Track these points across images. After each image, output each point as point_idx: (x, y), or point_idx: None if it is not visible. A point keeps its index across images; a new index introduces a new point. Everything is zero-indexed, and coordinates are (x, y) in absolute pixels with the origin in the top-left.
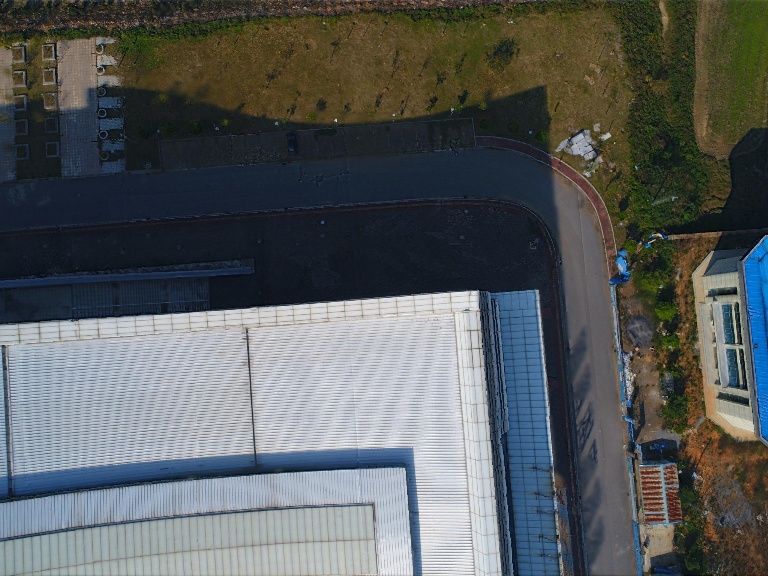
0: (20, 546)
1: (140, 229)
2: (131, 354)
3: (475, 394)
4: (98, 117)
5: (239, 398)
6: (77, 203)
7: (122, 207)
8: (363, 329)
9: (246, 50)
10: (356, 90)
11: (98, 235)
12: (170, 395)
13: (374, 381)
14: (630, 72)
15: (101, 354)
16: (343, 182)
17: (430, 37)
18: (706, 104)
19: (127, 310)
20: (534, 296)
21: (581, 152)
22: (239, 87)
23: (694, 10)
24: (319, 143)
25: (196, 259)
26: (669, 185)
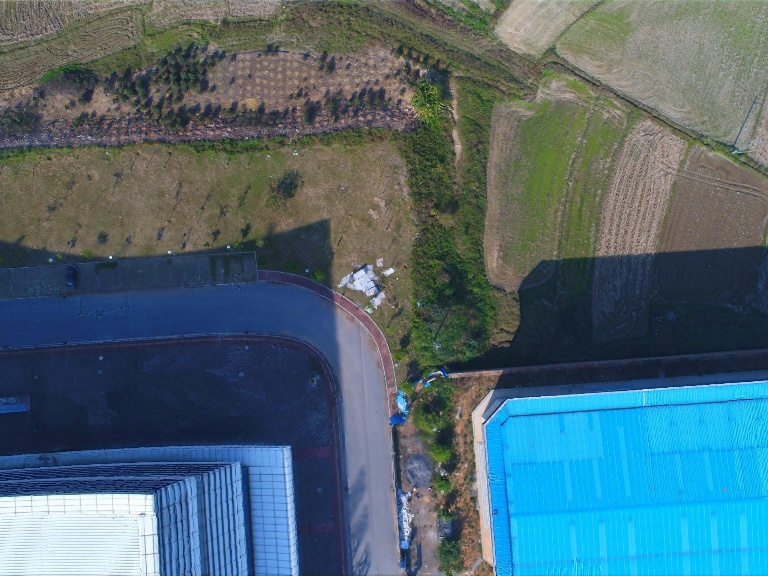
0: None
1: None
2: None
3: None
4: None
5: None
6: None
7: None
8: (54, 522)
9: (27, 181)
10: (138, 223)
11: None
12: None
13: (64, 575)
14: (414, 207)
15: None
16: (123, 316)
17: (214, 169)
18: (497, 235)
19: None
20: (282, 454)
21: (363, 288)
22: (19, 219)
23: (486, 139)
24: (100, 276)
25: None
26: (449, 323)
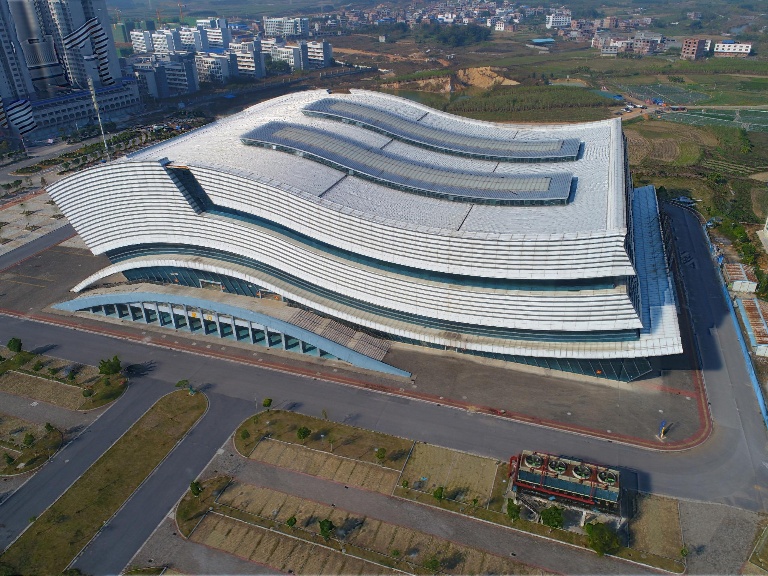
0: None
1: None
2: None
3: None
4: None
5: None
6: None
7: None
8: None
9: None
10: None
11: None
12: None
13: None
14: (712, 190)
15: None
16: None
17: None
18: None
19: None
20: (652, 185)
21: None
22: None
23: None
24: None
25: None
26: None
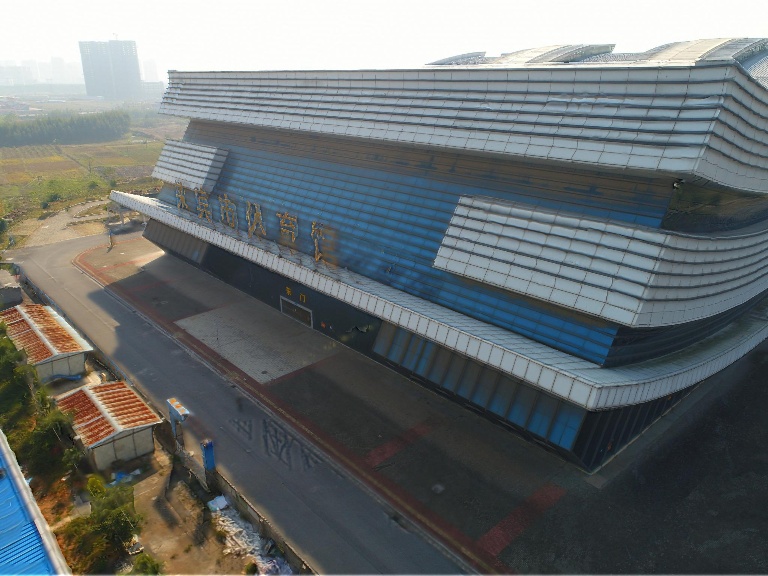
0: None
1: None
2: None
3: None
4: None
5: None
6: None
7: None
8: None
9: None
10: None
11: None
12: None
13: None
14: None
15: None
16: None
17: None
18: None
19: None
20: None
21: None
22: None
23: None
24: None
25: None
26: None
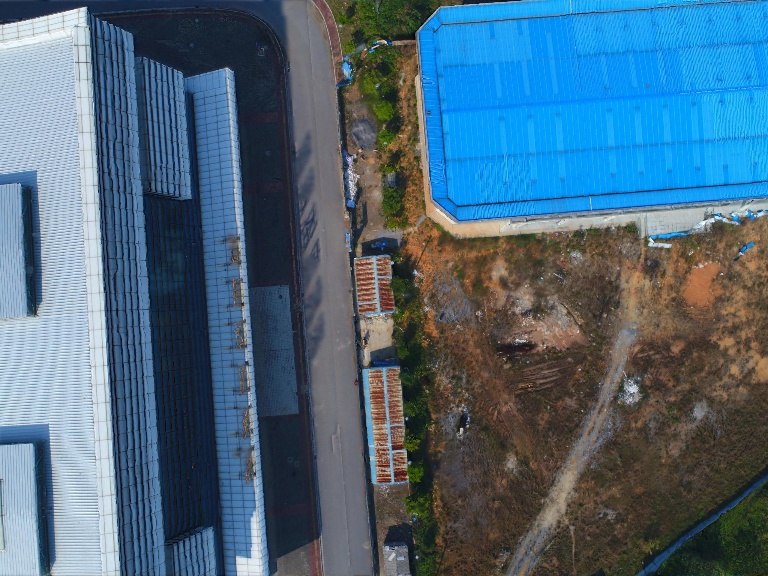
0: None
1: None
2: None
3: (81, 105)
4: None
5: None
6: None
7: None
8: None
9: None
10: None
11: None
12: None
13: (3, 109)
14: None
15: None
16: None
17: None
18: None
19: None
20: (224, 74)
21: None
22: None
23: None
24: None
25: None
26: None
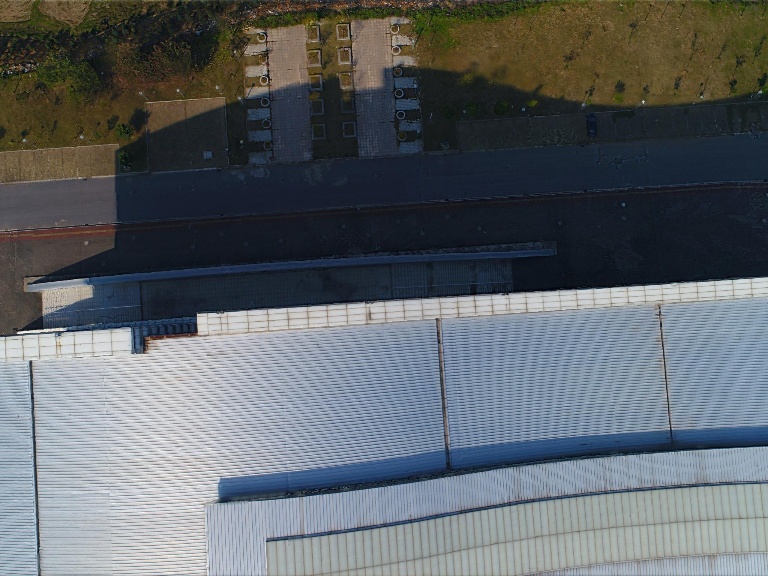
0: (471, 520)
1: (439, 210)
2: (549, 329)
3: None
4: (394, 97)
5: (654, 374)
6: (374, 183)
7: (420, 188)
8: None
9: (543, 31)
10: (655, 72)
11: (398, 216)
12: (586, 371)
13: None
14: None
15: (522, 329)
16: (642, 164)
17: (728, 20)
18: None
19: (441, 290)
20: None
21: None
22: (537, 68)
23: None
24: (617, 125)
25: (497, 240)
26: None
